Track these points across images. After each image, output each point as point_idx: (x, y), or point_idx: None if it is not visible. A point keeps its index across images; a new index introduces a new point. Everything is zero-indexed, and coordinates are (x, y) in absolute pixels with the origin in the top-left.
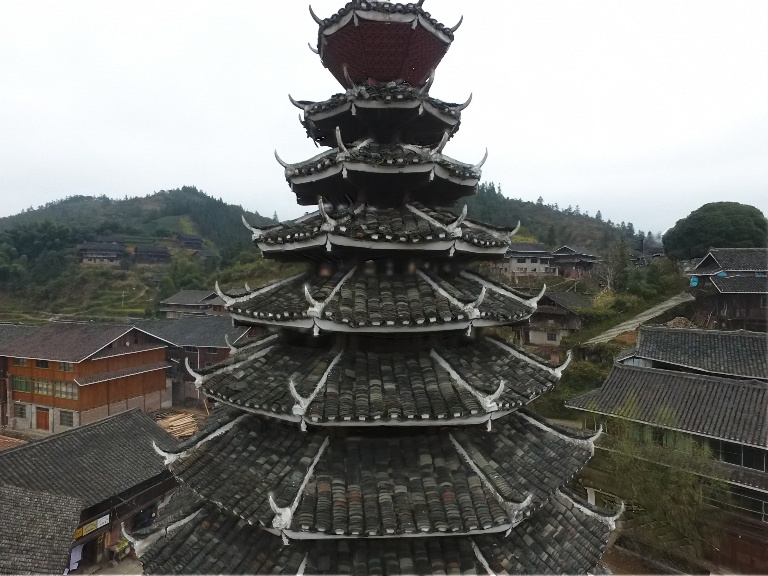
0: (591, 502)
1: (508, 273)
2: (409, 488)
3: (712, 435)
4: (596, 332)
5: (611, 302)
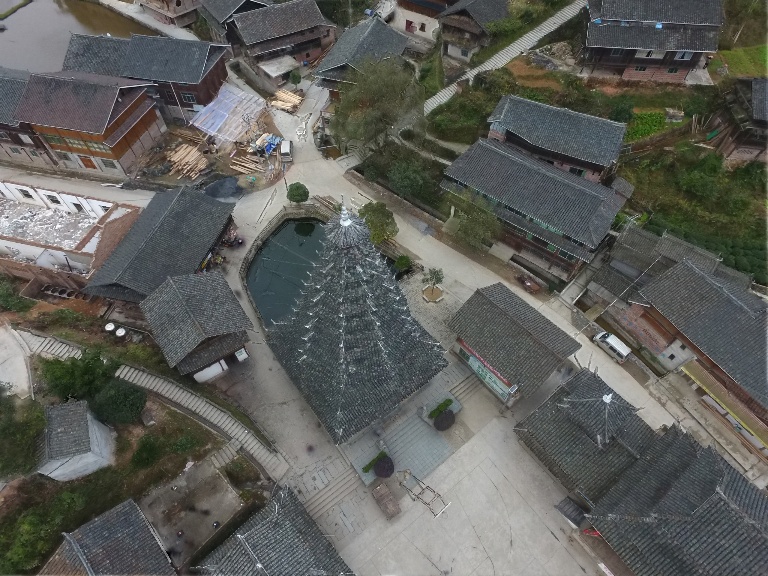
0: (453, 210)
1: None
2: (363, 334)
3: (504, 203)
4: (501, 47)
5: (523, 9)
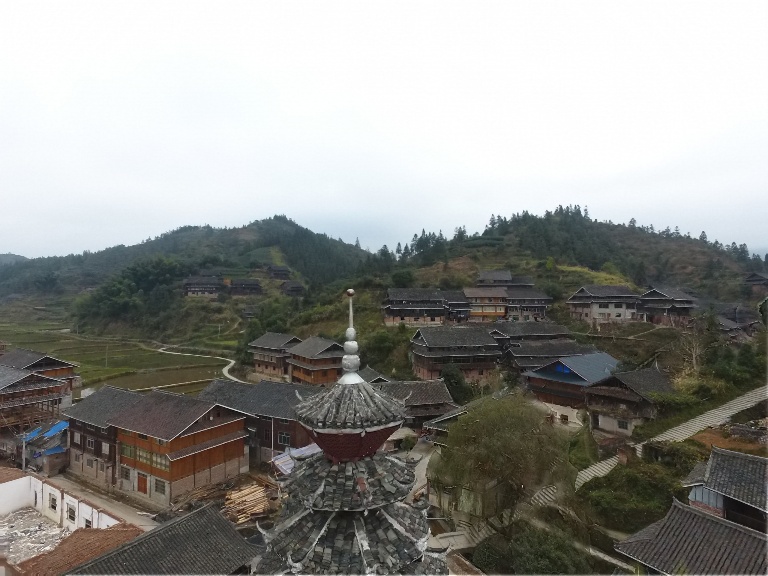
0: None
1: (589, 319)
2: None
3: None
4: (674, 422)
5: (694, 386)
